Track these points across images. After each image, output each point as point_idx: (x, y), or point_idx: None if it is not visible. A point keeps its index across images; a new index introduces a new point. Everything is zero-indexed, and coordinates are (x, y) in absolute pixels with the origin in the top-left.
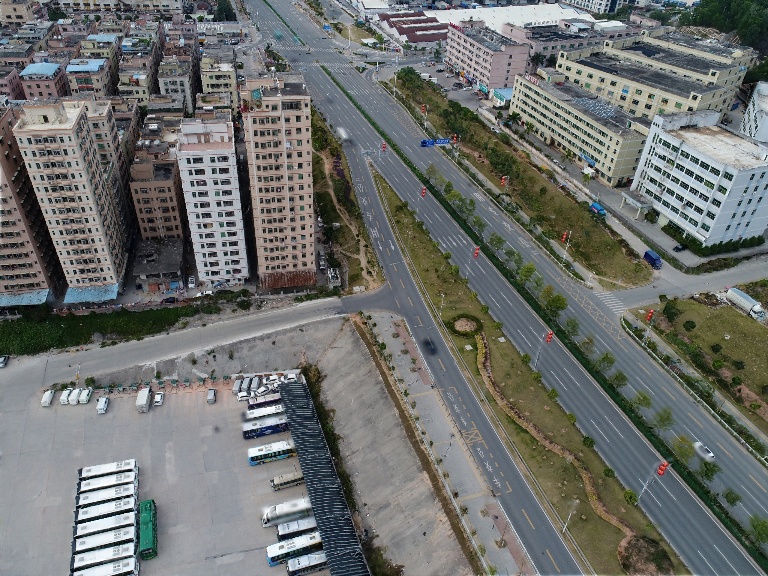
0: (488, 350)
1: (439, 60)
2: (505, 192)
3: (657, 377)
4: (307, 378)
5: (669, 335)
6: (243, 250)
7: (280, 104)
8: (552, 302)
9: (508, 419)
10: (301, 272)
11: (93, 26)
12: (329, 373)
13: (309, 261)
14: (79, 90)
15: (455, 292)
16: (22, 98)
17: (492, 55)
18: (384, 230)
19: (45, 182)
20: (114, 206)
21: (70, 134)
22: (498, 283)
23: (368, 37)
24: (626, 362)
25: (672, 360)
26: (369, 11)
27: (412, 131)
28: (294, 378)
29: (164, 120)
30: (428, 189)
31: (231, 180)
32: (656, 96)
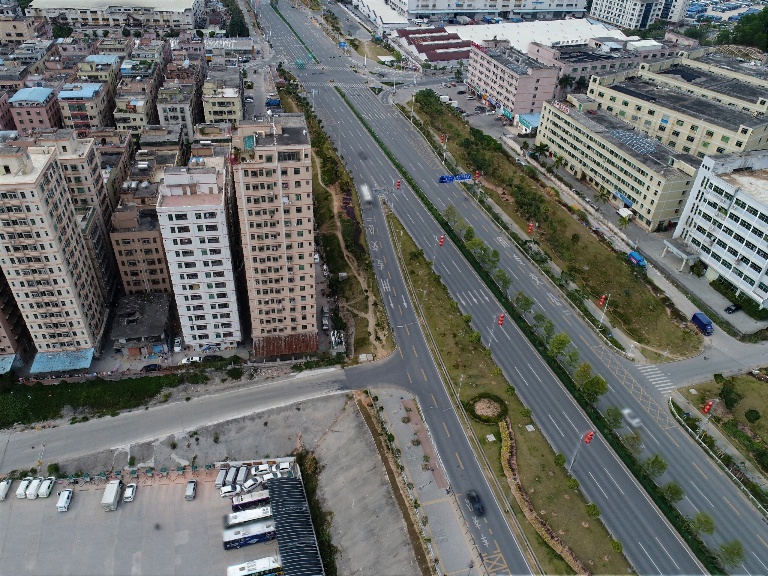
0: (514, 442)
1: (460, 80)
2: (533, 240)
3: (716, 482)
4: (302, 468)
5: (727, 425)
6: (235, 312)
7: (276, 155)
8: (590, 385)
9: (538, 539)
10: (301, 336)
11: (95, 45)
12: (328, 463)
13: (310, 323)
14: (72, 117)
15: (475, 363)
16: (13, 124)
17: (518, 79)
18: (396, 282)
19: (6, 241)
20: (93, 258)
21: (32, 189)
22: (525, 352)
23: (385, 54)
24: (678, 461)
25: (734, 461)
26: (387, 26)
27: (430, 162)
28: (287, 468)
29: (158, 154)
30: (446, 232)
31: (220, 238)
32: (700, 128)
